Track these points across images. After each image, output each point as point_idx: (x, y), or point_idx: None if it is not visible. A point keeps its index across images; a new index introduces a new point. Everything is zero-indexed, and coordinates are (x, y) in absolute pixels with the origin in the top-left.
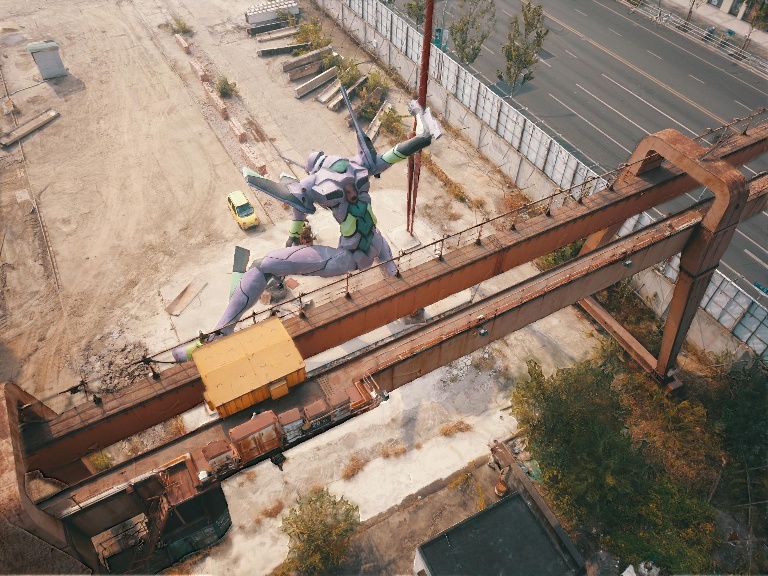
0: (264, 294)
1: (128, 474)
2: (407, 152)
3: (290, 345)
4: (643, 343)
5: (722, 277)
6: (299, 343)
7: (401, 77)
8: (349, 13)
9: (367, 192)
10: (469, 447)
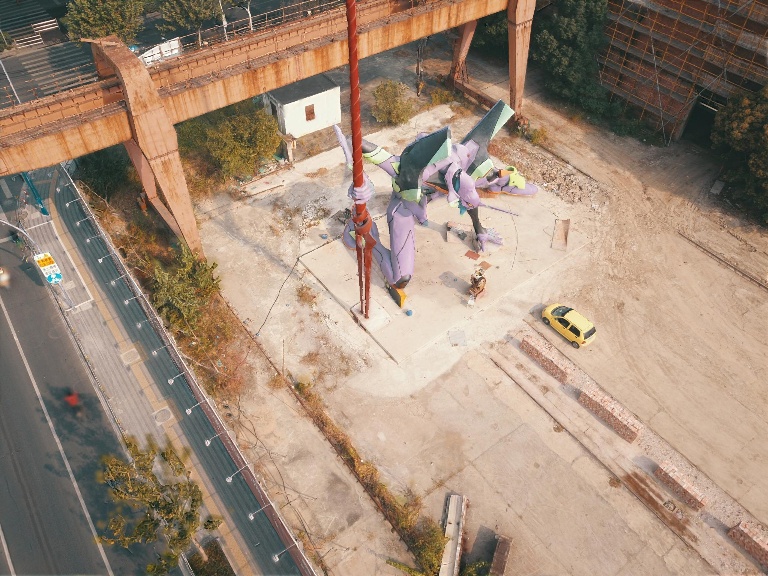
0: None
1: None
2: None
3: None
4: (149, 236)
5: None
6: None
7: None
8: None
9: None
10: (308, 166)
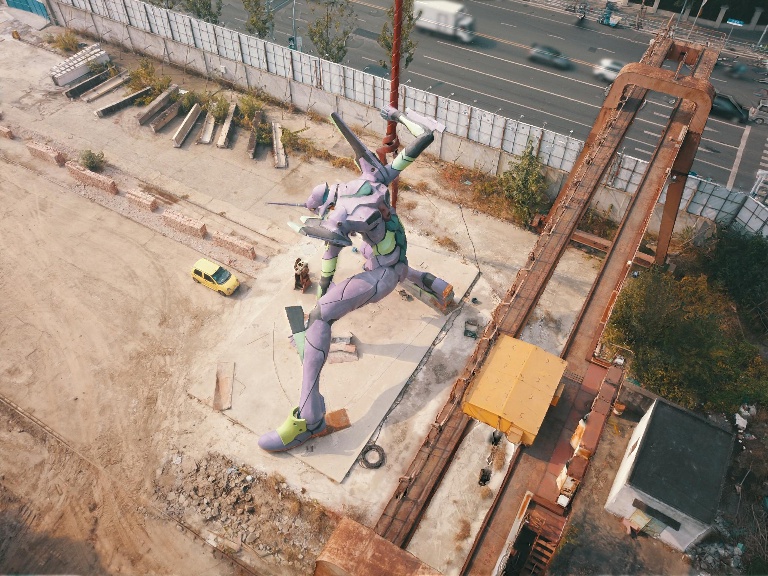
0: None
1: (494, 540)
2: (416, 154)
3: (541, 352)
4: None
5: None
6: None
7: (270, 95)
8: (176, 46)
9: None
10: None
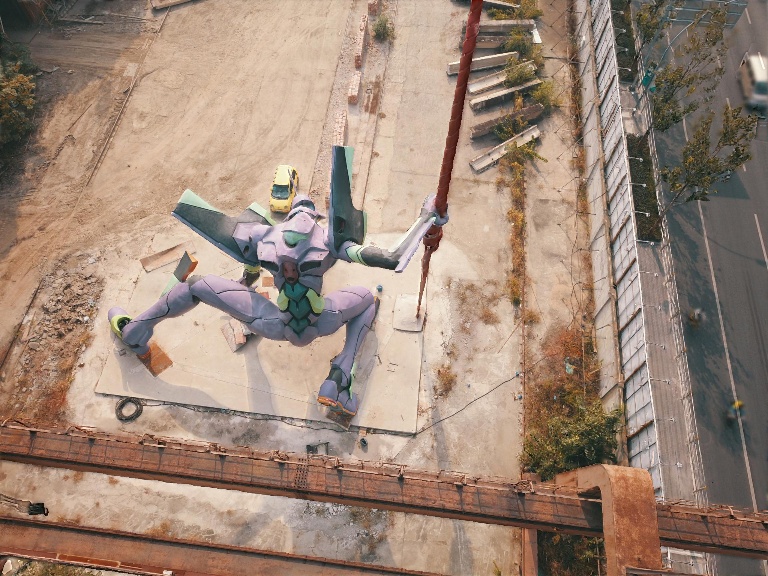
0: None
1: None
2: (369, 262)
3: None
4: None
5: None
6: (13, 457)
7: (580, 101)
8: None
9: (319, 275)
10: None
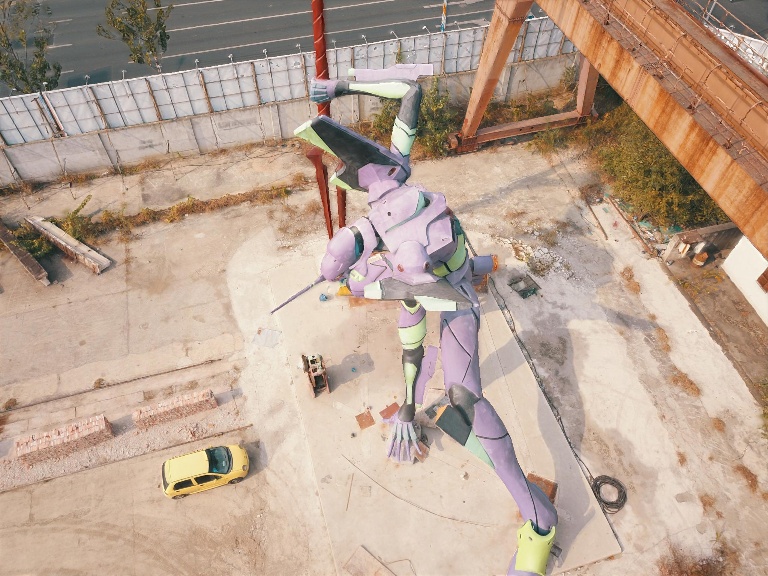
0: (415, 450)
1: None
2: None
3: None
4: None
5: (541, 20)
6: None
7: None
8: None
9: None
10: (651, 275)
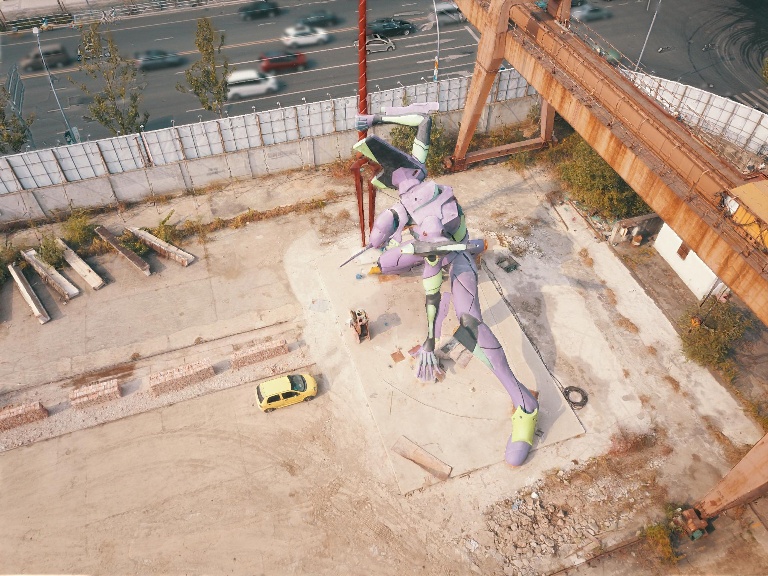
0: (436, 373)
1: None
2: None
3: (758, 184)
4: None
5: None
6: None
7: None
8: None
9: None
10: (601, 253)
